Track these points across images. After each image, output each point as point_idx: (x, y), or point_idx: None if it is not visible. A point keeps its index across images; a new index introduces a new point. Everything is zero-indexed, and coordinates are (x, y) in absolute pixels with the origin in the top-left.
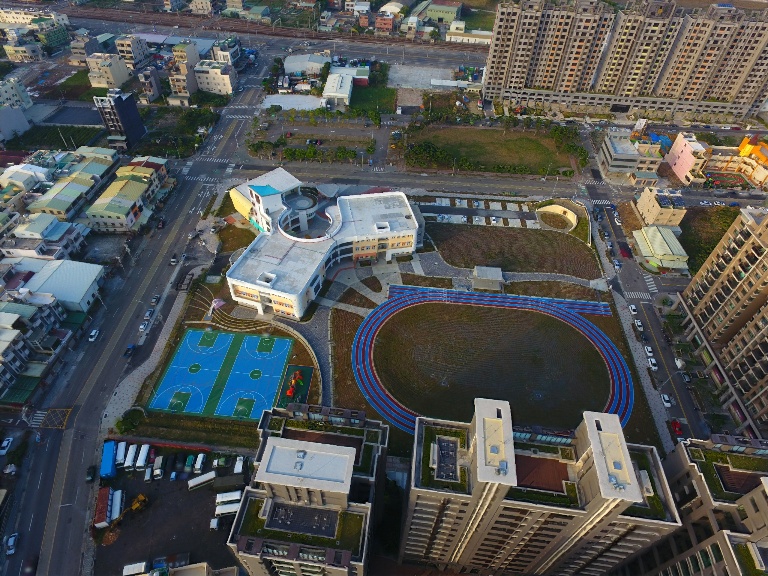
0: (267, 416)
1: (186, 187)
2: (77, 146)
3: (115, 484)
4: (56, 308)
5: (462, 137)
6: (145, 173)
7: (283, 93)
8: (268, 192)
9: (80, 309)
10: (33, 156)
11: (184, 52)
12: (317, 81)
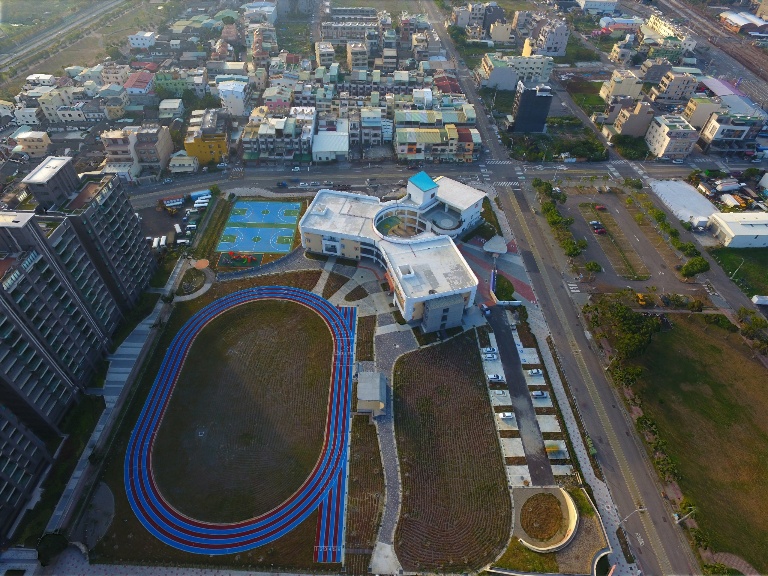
0: (114, 175)
1: (468, 168)
2: (500, 112)
3: (189, 202)
4: (303, 144)
5: (745, 387)
6: (450, 135)
7: (700, 190)
8: (420, 184)
9: (313, 156)
10: (456, 95)
11: (696, 106)
12: (764, 210)
